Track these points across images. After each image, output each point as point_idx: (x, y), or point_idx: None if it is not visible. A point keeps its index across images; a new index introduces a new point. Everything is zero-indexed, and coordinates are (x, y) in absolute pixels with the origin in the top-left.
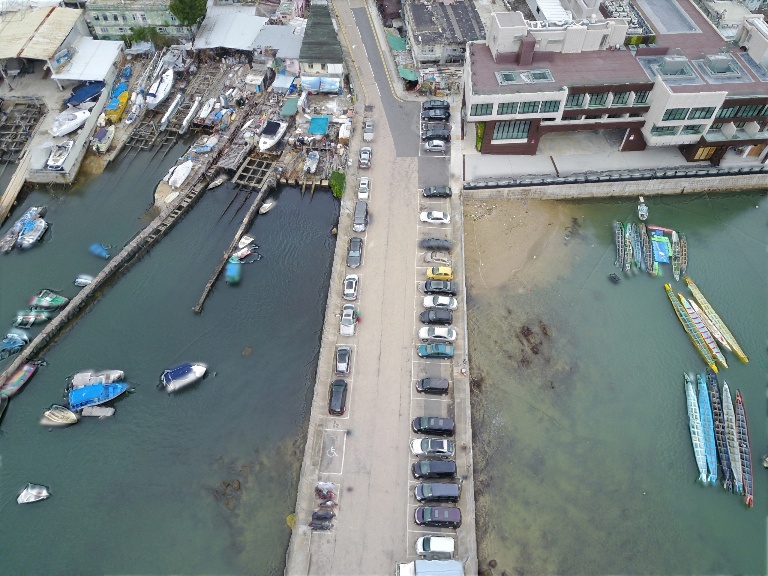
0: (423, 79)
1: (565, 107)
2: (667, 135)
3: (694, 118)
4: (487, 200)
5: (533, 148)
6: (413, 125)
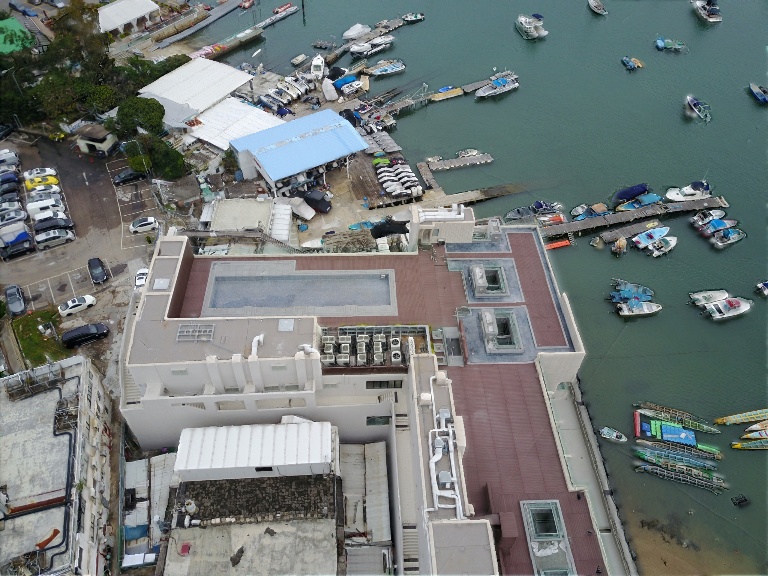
0: None
1: None
2: None
3: None
4: None
5: None
6: None
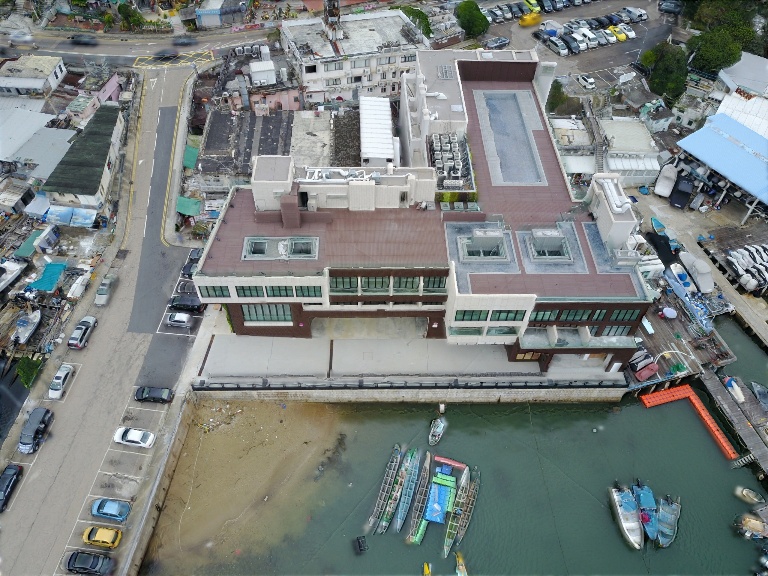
0: (194, 220)
1: (334, 290)
2: (469, 335)
3: (500, 320)
4: (233, 400)
5: (305, 331)
6: (167, 283)
